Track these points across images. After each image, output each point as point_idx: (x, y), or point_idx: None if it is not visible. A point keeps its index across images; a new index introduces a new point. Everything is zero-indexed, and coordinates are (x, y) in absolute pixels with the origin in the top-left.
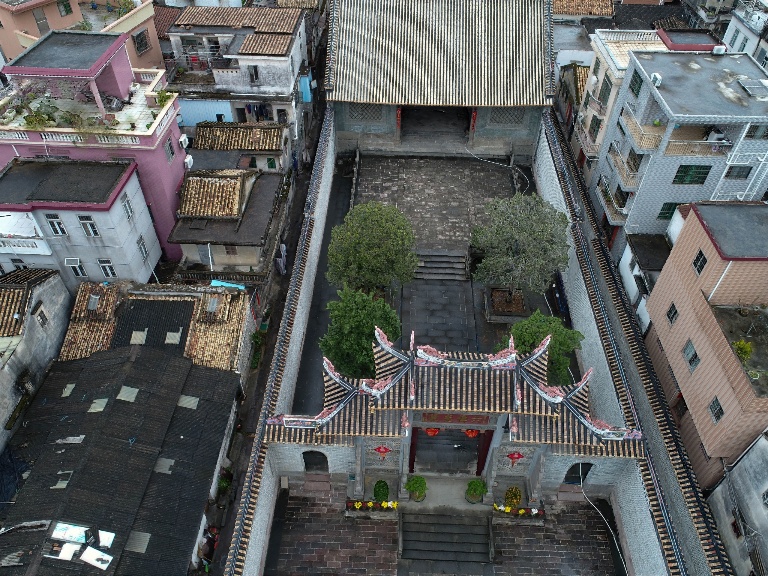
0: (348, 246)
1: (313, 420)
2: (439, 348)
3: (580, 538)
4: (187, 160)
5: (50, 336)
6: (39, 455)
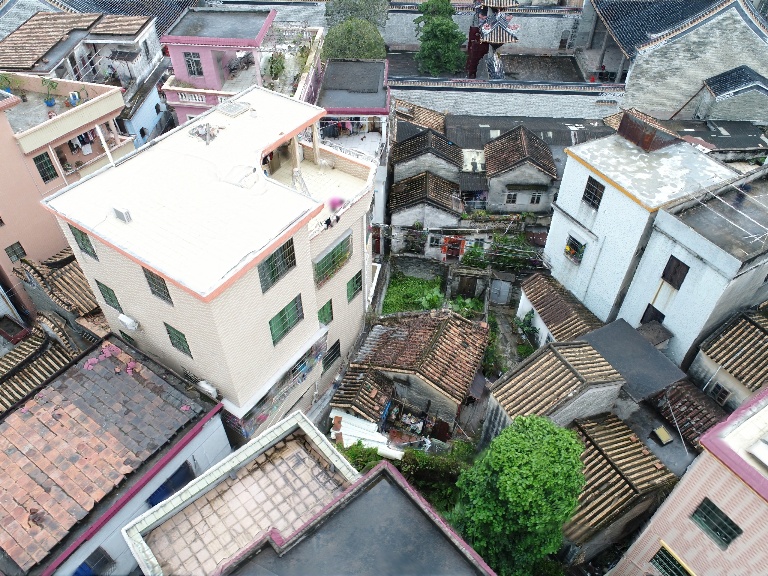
0: None
1: None
2: None
3: None
4: None
5: None
6: None
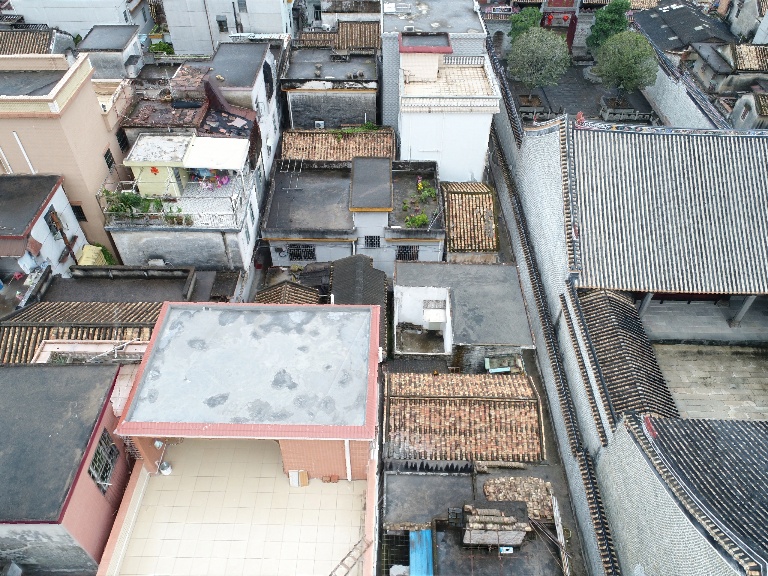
0: None
1: None
2: (565, 89)
3: None
4: None
5: None
6: None
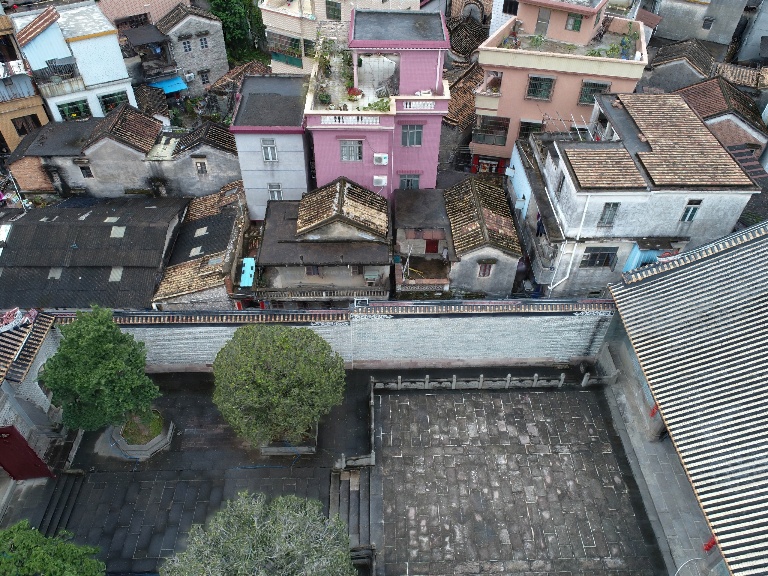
0: None
1: None
2: (198, 516)
3: None
4: (375, 177)
5: (203, 183)
6: (86, 208)
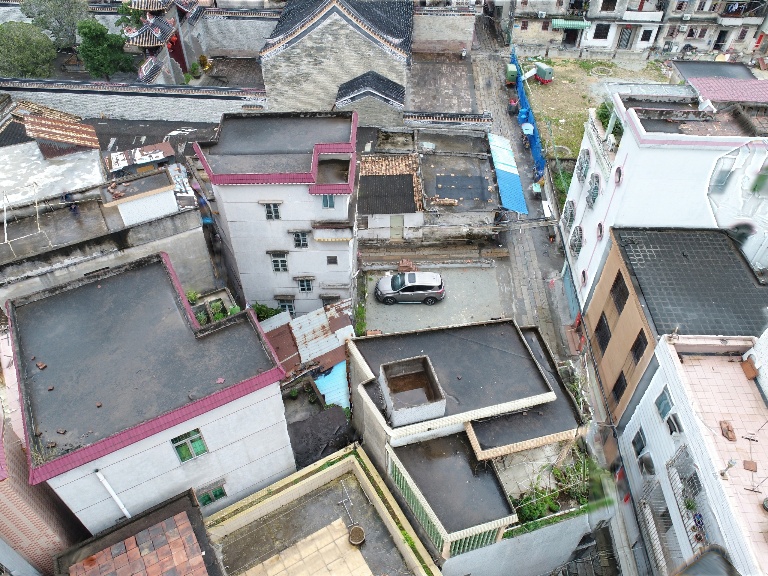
0: (24, 44)
1: (148, 62)
2: None
3: (225, 64)
4: None
5: None
6: None
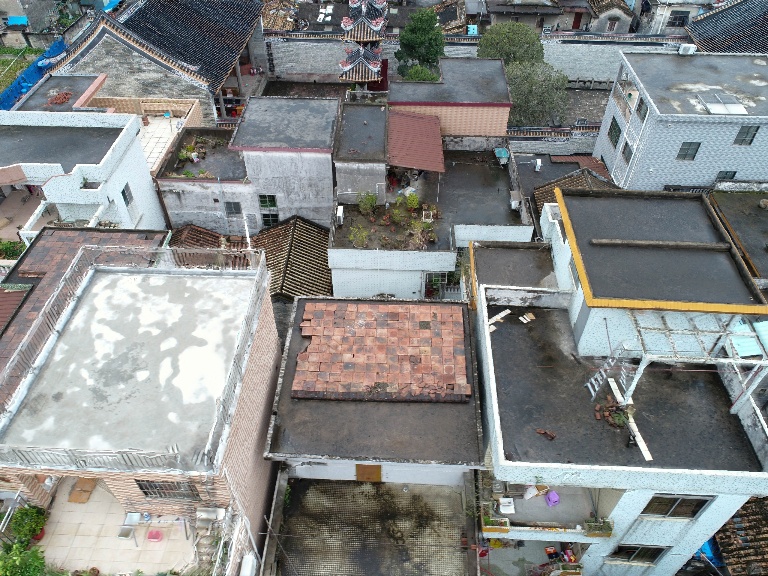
0: None
1: None
2: None
3: None
4: None
5: None
6: None
